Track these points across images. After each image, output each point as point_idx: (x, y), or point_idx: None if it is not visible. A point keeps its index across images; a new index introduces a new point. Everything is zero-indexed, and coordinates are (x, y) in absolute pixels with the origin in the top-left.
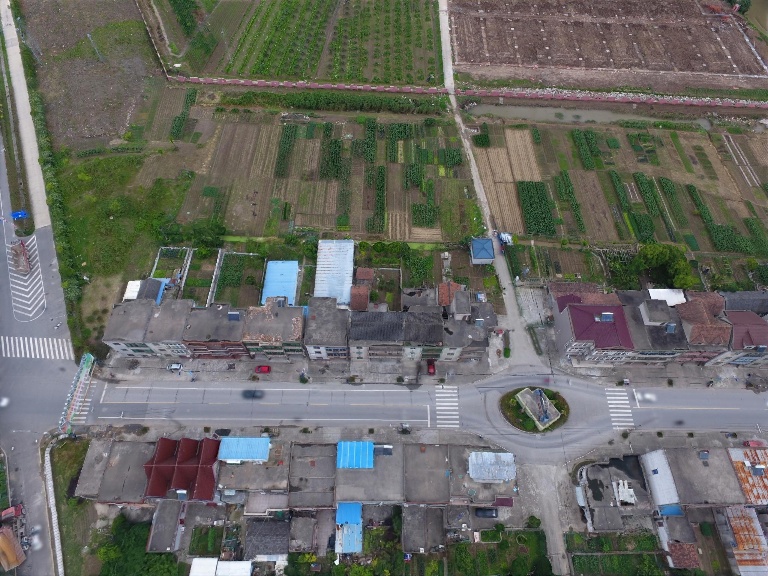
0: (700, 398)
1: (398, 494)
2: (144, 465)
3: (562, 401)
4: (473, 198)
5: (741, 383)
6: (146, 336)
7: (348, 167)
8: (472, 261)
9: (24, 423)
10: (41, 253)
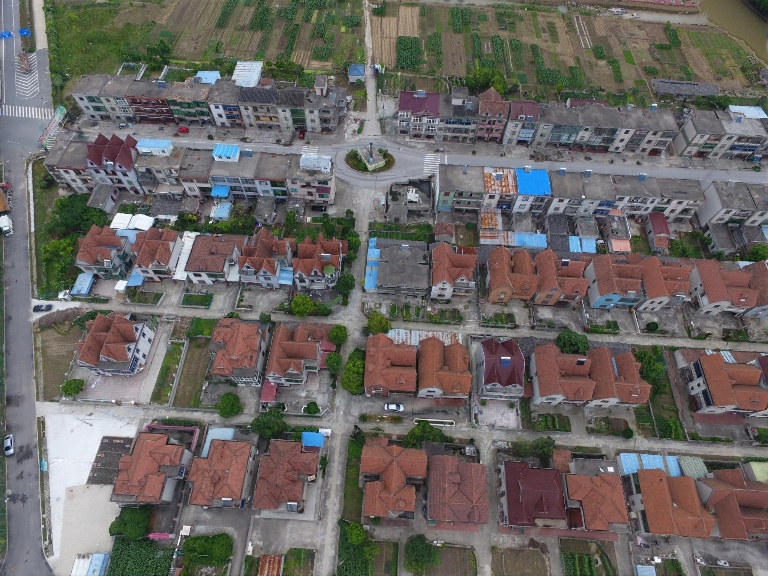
0: (493, 162)
1: (251, 175)
2: (87, 144)
3: (390, 157)
4: (362, 46)
5: (527, 156)
6: (101, 93)
7: (271, 23)
8: (349, 80)
9: (17, 149)
10: (39, 63)
